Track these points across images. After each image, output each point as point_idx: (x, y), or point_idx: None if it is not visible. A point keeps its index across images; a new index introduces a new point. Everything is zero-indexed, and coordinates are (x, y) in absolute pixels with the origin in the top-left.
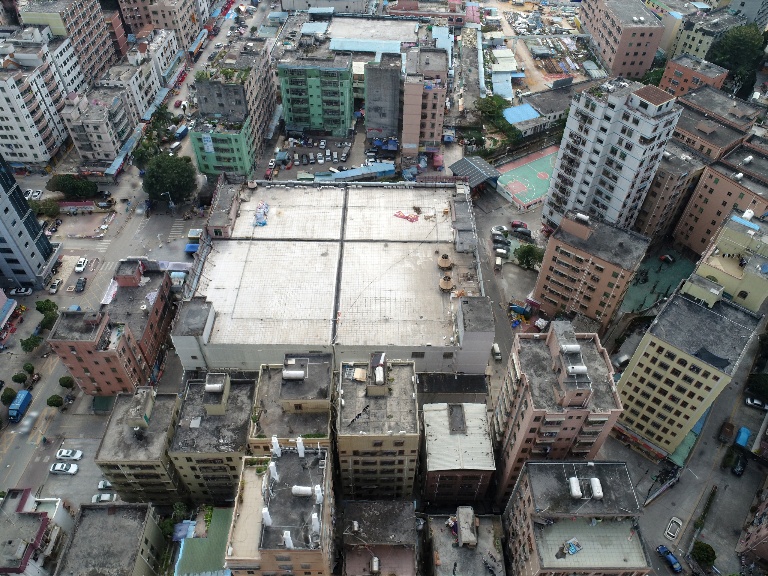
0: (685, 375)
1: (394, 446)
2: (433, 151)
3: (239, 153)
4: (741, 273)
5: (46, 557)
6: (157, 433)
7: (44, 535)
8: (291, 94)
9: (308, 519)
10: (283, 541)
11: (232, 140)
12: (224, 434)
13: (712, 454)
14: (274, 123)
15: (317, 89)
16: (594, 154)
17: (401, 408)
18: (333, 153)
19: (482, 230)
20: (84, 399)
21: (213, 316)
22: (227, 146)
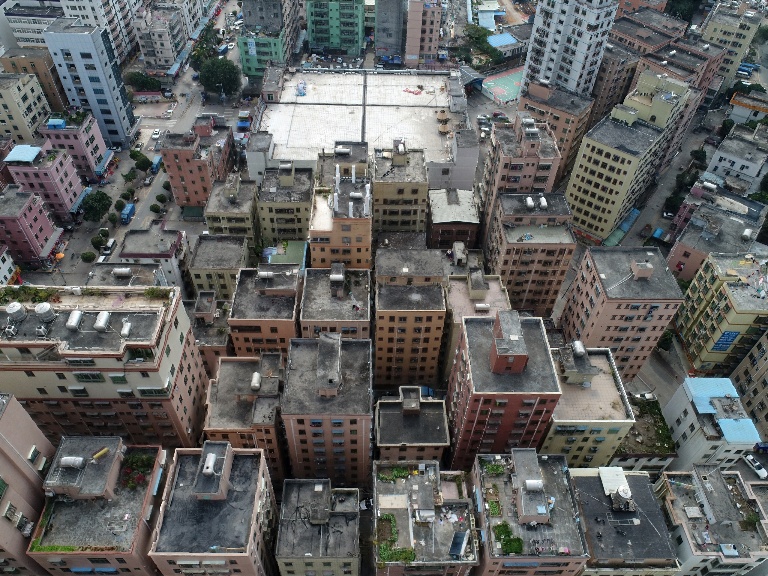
0: (610, 166)
1: (411, 194)
2: (430, 63)
3: (276, 56)
4: None
5: (180, 260)
6: (245, 201)
7: (179, 245)
8: (315, 16)
9: (361, 209)
10: (346, 217)
11: (272, 44)
12: (294, 196)
13: (635, 244)
14: (300, 42)
15: (336, 12)
16: (555, 44)
17: (416, 171)
18: (349, 65)
19: (470, 96)
20: (174, 212)
21: (273, 145)
22: (267, 50)
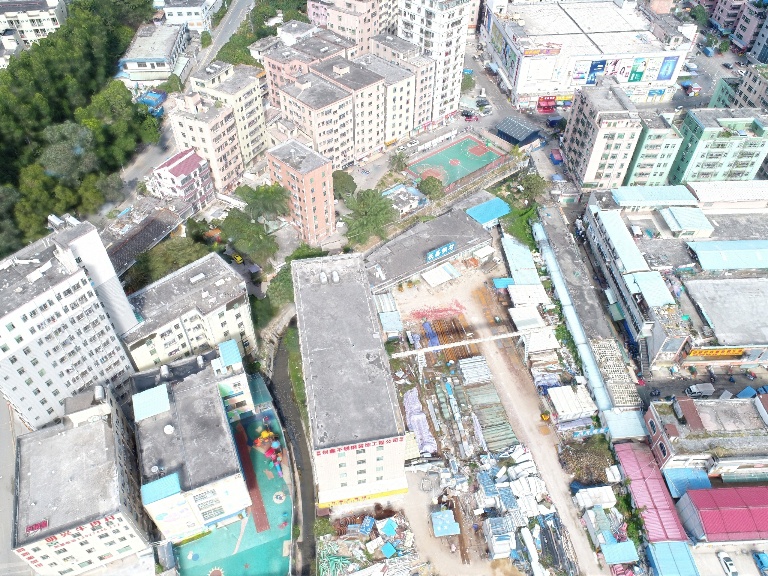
0: None
1: None
2: None
3: None
4: None
5: None
6: None
7: None
8: None
9: None
10: None
11: None
12: None
13: None
14: None
15: None
16: None
17: None
18: None
19: None
20: None
21: None
22: None
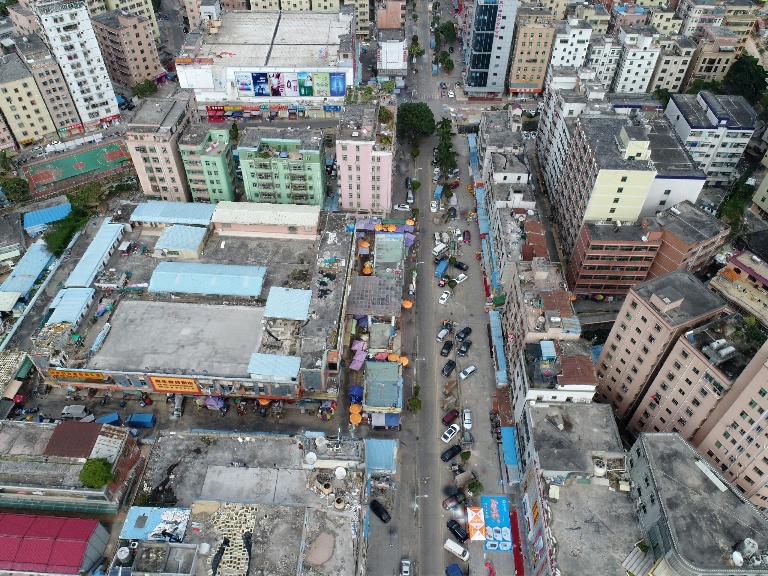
0: None
1: None
2: None
3: None
4: None
5: None
6: None
7: None
8: None
9: None
10: None
11: None
12: None
13: None
14: None
15: None
16: None
17: None
18: None
19: None
20: None
21: None
22: None
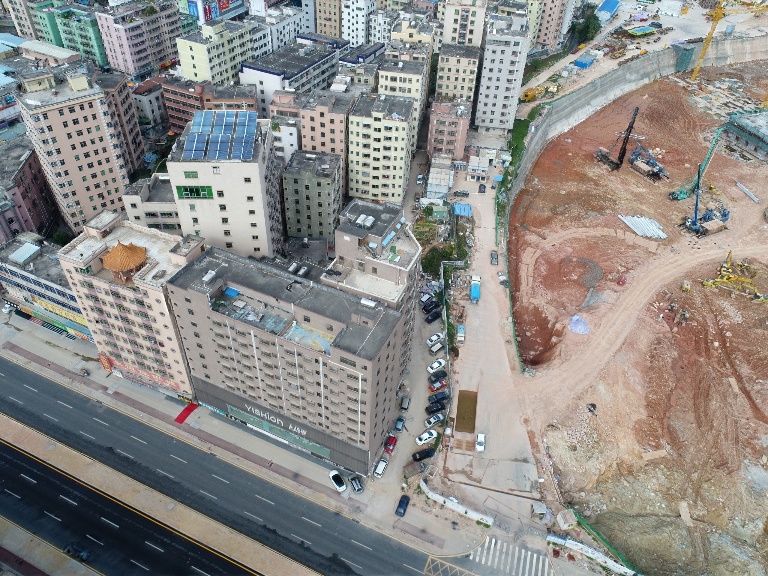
0: None
1: None
2: None
3: None
4: None
5: None
6: None
7: None
8: None
9: None
10: None
11: None
12: None
13: None
14: None
15: None
16: None
17: None
18: None
19: None
20: None
21: None
22: None
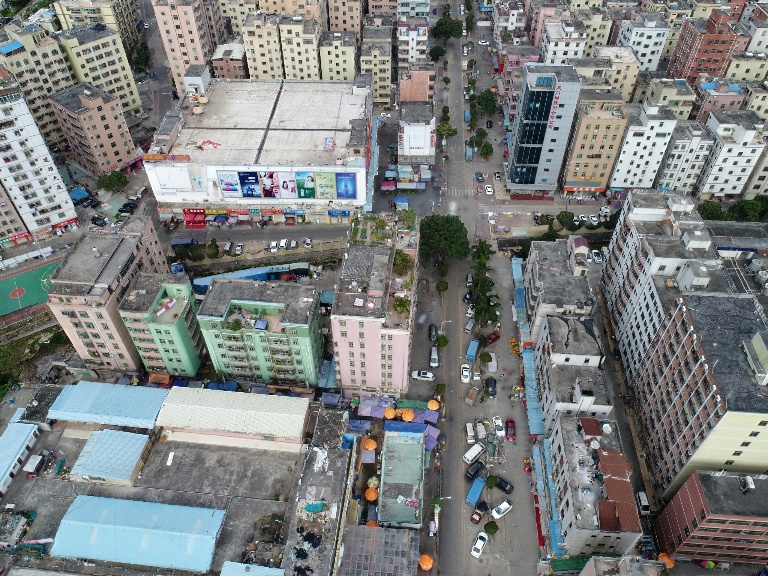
0: None
1: None
2: None
3: None
4: (39, 42)
5: None
6: (367, 49)
7: None
8: None
9: None
10: None
11: None
12: None
13: None
14: None
15: None
16: None
17: None
18: None
19: None
20: (435, 122)
21: None
22: None
